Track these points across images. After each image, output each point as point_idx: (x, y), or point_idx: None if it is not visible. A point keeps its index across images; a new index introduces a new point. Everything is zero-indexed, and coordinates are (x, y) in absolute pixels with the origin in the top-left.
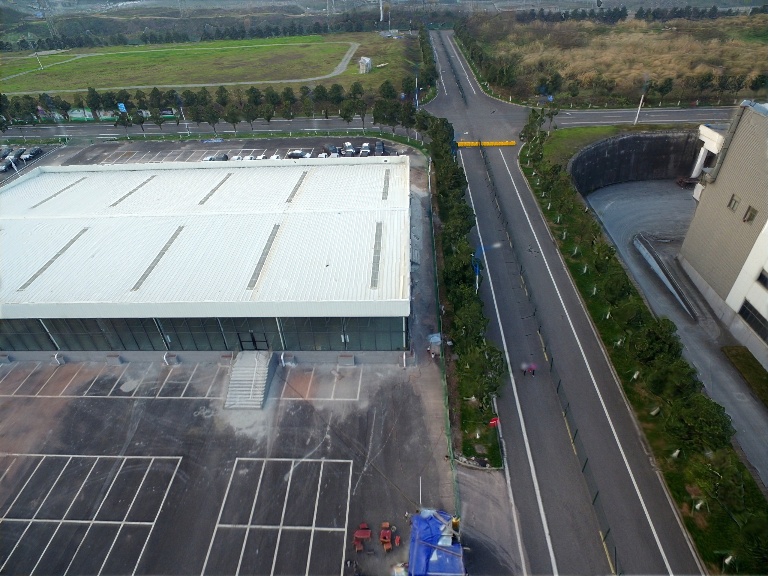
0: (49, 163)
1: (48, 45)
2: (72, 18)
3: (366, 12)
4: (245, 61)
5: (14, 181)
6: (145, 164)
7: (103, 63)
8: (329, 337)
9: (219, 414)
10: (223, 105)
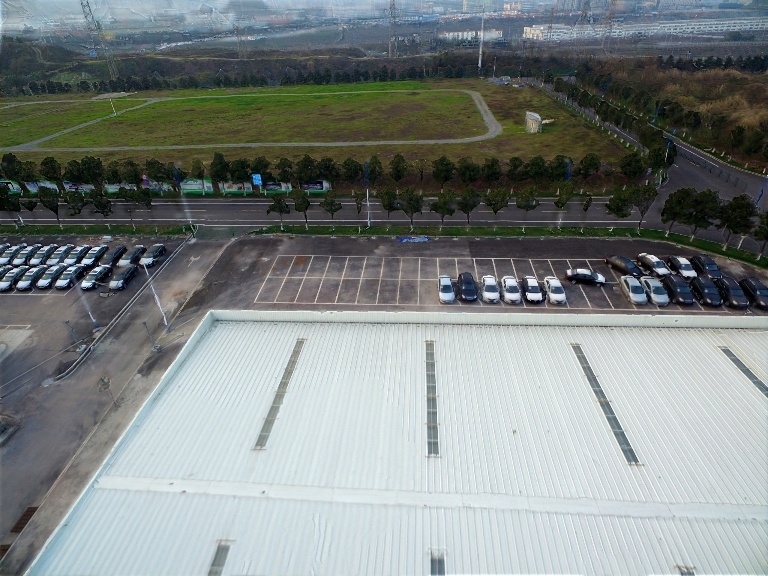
0: (183, 273)
1: (111, 87)
2: (128, 58)
3: (460, 56)
4: (358, 111)
5: (183, 351)
6: (399, 313)
7: (185, 110)
8: None
9: None
10: (397, 179)
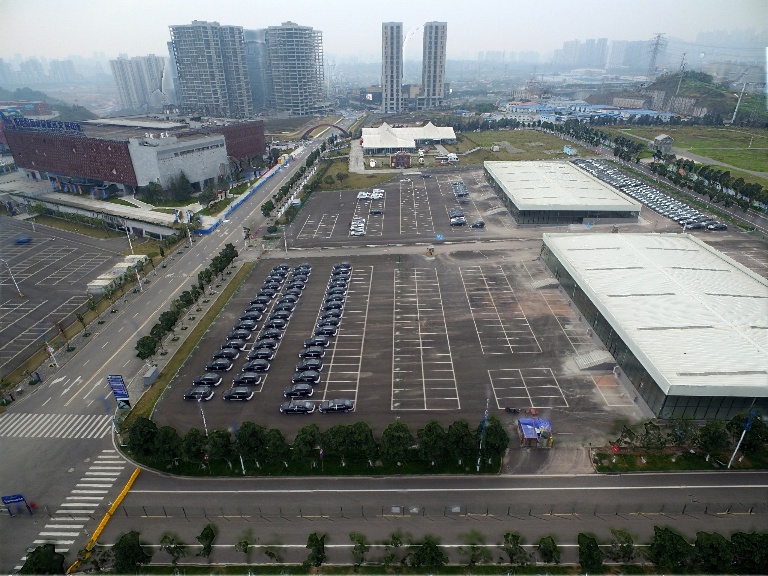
0: (717, 237)
1: None
2: None
3: None
4: None
5: (665, 234)
6: (737, 262)
7: None
8: (636, 375)
9: (570, 357)
10: None
